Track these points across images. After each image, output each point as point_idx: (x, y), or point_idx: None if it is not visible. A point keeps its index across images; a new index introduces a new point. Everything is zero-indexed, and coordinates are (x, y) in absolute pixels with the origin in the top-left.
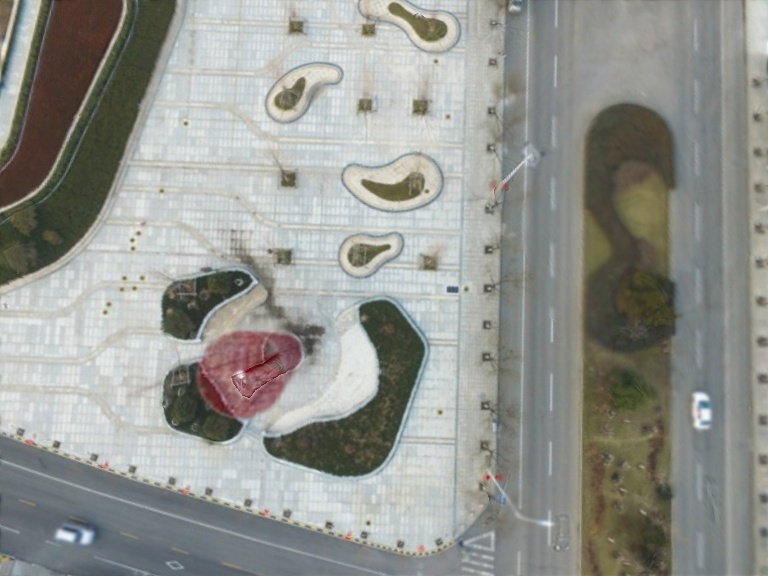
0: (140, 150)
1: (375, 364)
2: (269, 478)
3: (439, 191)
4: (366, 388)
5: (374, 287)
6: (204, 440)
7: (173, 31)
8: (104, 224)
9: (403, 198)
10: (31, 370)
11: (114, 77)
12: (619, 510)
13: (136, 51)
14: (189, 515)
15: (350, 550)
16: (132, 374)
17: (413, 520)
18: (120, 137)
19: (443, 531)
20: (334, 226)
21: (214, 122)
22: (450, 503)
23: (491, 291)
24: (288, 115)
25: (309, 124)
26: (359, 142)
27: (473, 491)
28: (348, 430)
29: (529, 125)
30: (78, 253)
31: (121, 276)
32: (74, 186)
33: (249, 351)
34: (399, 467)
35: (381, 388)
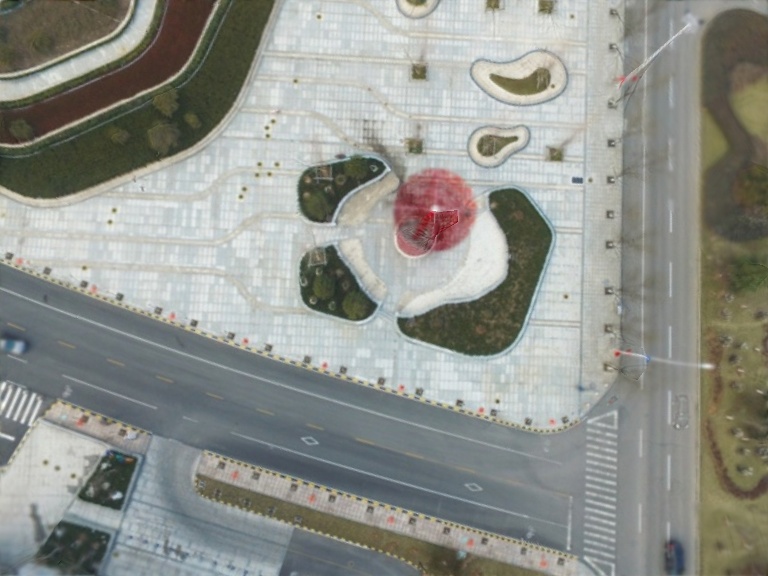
0: (274, 41)
1: (504, 250)
2: (402, 357)
3: (564, 87)
4: (494, 273)
5: (502, 177)
6: (339, 320)
7: None
8: (239, 112)
9: (530, 92)
10: (168, 251)
11: None
12: (737, 389)
13: None
14: (324, 393)
15: (480, 427)
16: (268, 256)
17: (541, 399)
18: (256, 27)
19: (569, 409)
20: (463, 118)
21: (346, 16)
22: (576, 383)
23: (614, 182)
24: (419, 11)
25: (438, 20)
26: (487, 38)
27: (598, 372)
28: (479, 311)
29: (649, 27)
30: (214, 139)
31: (256, 162)
32: (212, 73)
33: (382, 236)
34: (527, 348)
35: (510, 272)
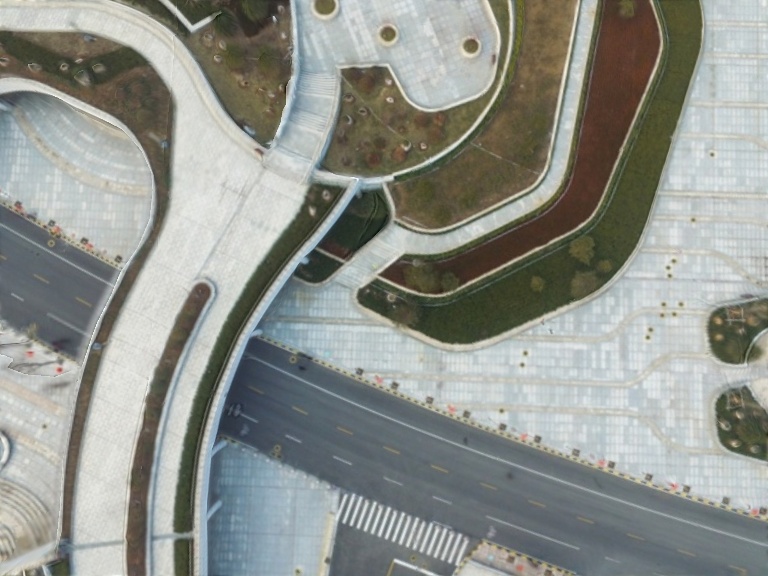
0: (669, 180)
1: None
2: None
3: None
4: None
5: None
6: (758, 461)
7: (696, 65)
8: (639, 252)
9: None
10: (581, 393)
11: (650, 111)
12: None
13: (669, 86)
14: (743, 534)
15: None
16: (679, 397)
17: None
18: (656, 168)
19: None
20: None
21: (740, 153)
22: None
23: None
24: None
25: None
26: None
27: None
28: None
29: None
30: (616, 280)
31: (660, 302)
32: (617, 216)
33: None
34: None
35: None
